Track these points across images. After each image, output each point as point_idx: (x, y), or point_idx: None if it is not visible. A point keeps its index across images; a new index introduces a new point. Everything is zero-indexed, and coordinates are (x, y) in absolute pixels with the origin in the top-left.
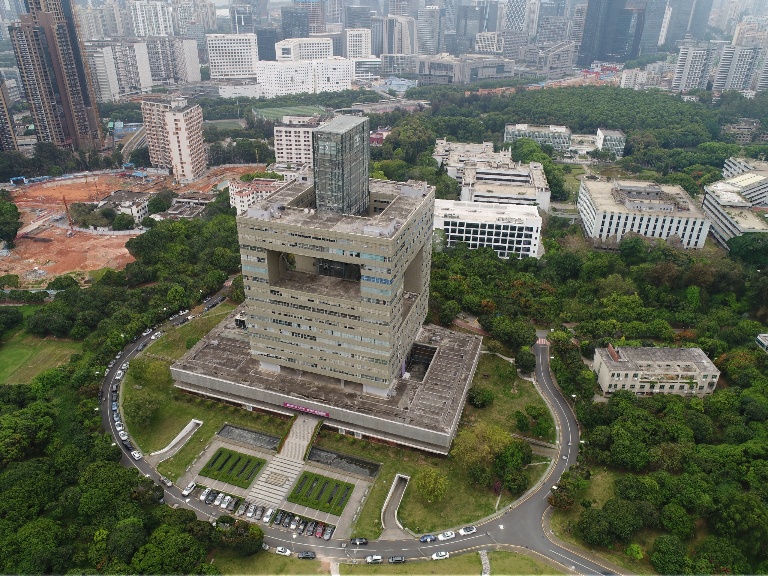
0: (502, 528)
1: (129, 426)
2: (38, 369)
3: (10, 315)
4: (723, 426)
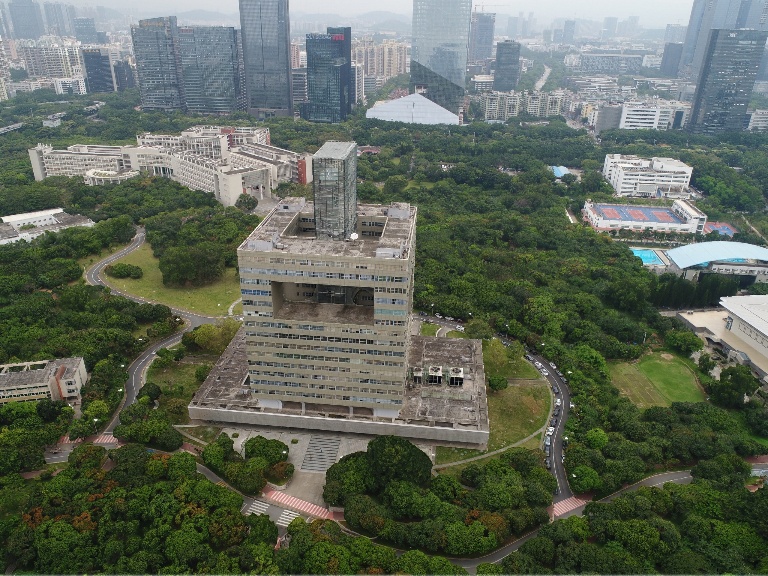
0: (219, 304)
1: (486, 341)
2: (635, 386)
3: (756, 415)
4: (9, 356)
